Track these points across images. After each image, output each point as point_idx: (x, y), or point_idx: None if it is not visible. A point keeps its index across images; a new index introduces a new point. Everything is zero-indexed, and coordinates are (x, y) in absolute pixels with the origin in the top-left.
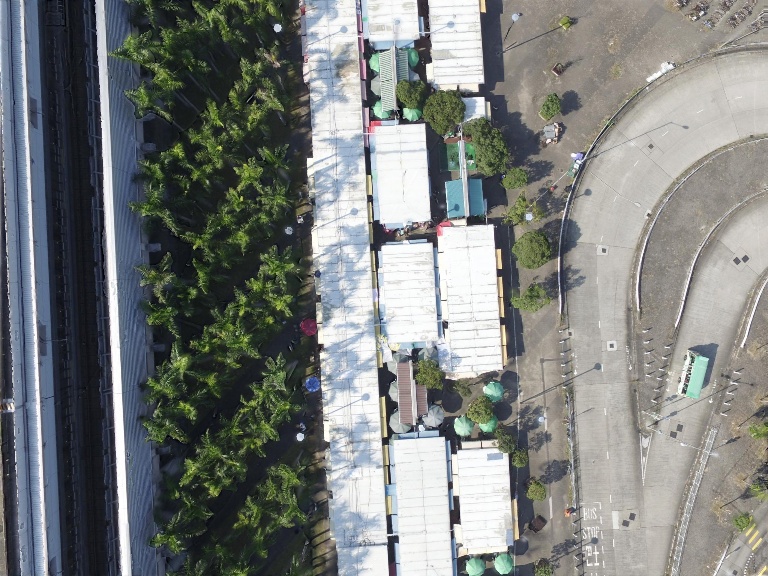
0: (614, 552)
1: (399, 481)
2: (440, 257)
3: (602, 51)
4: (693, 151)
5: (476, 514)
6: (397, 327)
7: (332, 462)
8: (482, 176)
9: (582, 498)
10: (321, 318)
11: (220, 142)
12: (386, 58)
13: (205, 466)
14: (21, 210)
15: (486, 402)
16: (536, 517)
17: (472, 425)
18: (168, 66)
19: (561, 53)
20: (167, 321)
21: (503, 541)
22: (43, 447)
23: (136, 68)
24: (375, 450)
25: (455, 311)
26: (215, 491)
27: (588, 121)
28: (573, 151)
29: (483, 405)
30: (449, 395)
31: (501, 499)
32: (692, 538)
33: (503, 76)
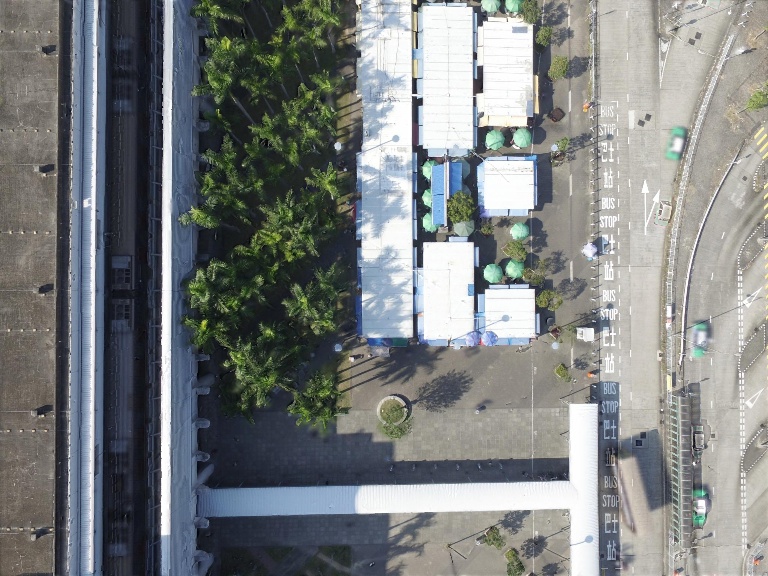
0: (629, 149)
1: (426, 45)
2: None
3: None
4: None
5: (499, 82)
6: None
7: (362, 21)
8: None
9: (600, 95)
10: None
11: None
12: None
13: None
14: None
15: None
16: (555, 108)
17: (499, 0)
18: None
19: None
20: None
21: (523, 111)
22: None
23: None
24: (404, 13)
25: None
26: None
27: None
28: None
29: None
30: None
31: (523, 71)
32: (705, 141)
33: None
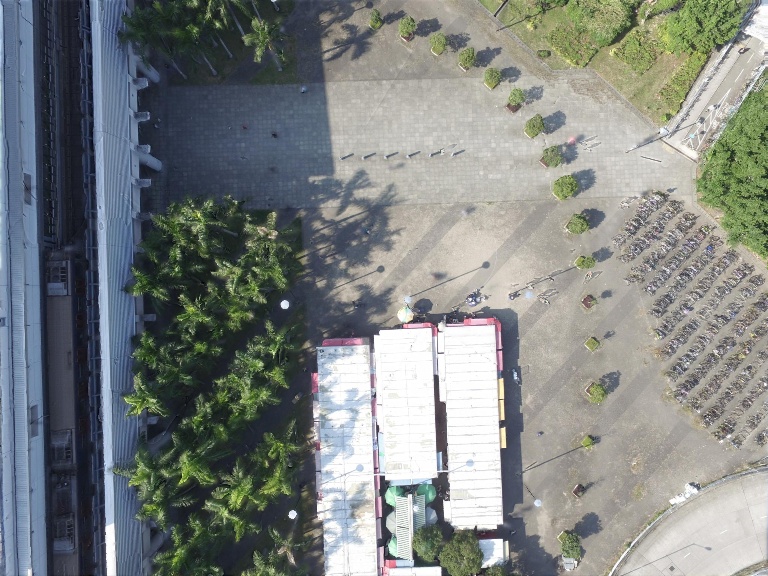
0: None
1: None
2: None
3: (624, 471)
4: (715, 573)
5: None
6: None
7: None
8: None
9: None
10: None
11: None
12: (403, 504)
13: None
14: None
15: None
16: None
17: None
18: (179, 570)
19: (582, 473)
20: None
21: None
22: None
23: (146, 547)
24: None
25: None
26: None
27: (608, 544)
28: (592, 575)
29: None
30: None
31: None
32: None
33: (522, 497)
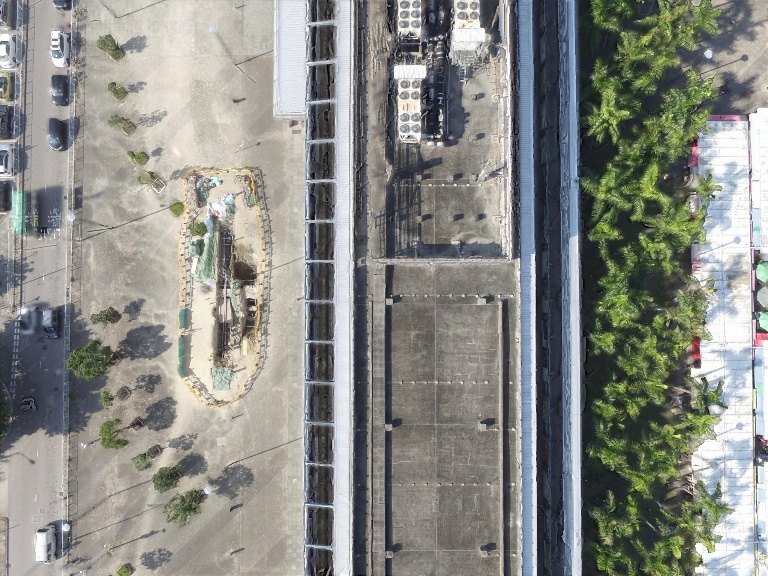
0: None
1: None
2: None
3: None
4: None
5: None
6: None
7: None
8: None
9: None
10: None
11: (658, 376)
12: None
13: None
14: (524, 474)
15: None
16: None
17: None
18: None
19: None
20: None
21: None
22: None
23: None
24: None
25: None
26: None
27: None
28: None
29: None
30: None
31: None
32: None
33: None
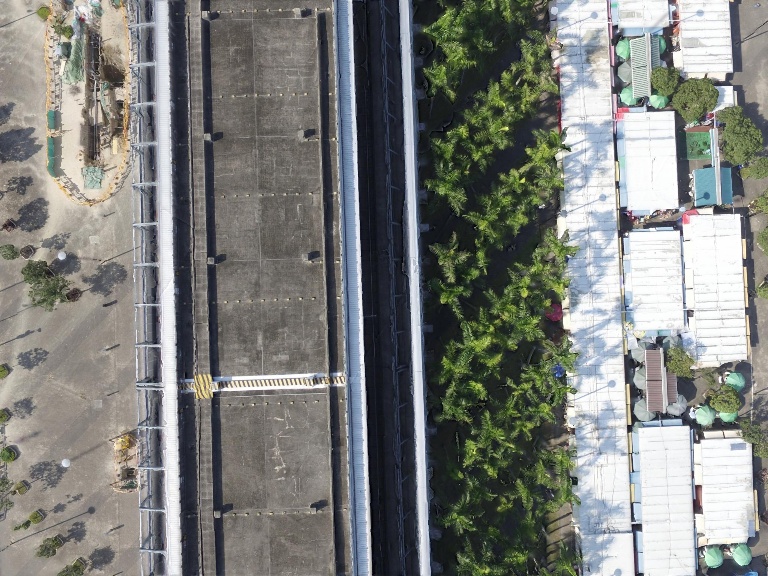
0: None
1: (644, 469)
2: (686, 245)
3: None
4: None
5: (719, 504)
6: (644, 314)
7: (578, 448)
8: (730, 165)
9: None
10: (568, 304)
11: (502, 123)
12: (639, 45)
13: (481, 448)
14: (347, 184)
15: (734, 392)
16: (767, 509)
17: (715, 415)
18: None
19: None
20: (452, 301)
21: (745, 532)
22: (366, 422)
23: None
24: (620, 437)
25: (701, 300)
26: (494, 473)
27: None
28: None
29: (733, 394)
30: (683, 384)
31: (744, 490)
32: None
33: (741, 66)
